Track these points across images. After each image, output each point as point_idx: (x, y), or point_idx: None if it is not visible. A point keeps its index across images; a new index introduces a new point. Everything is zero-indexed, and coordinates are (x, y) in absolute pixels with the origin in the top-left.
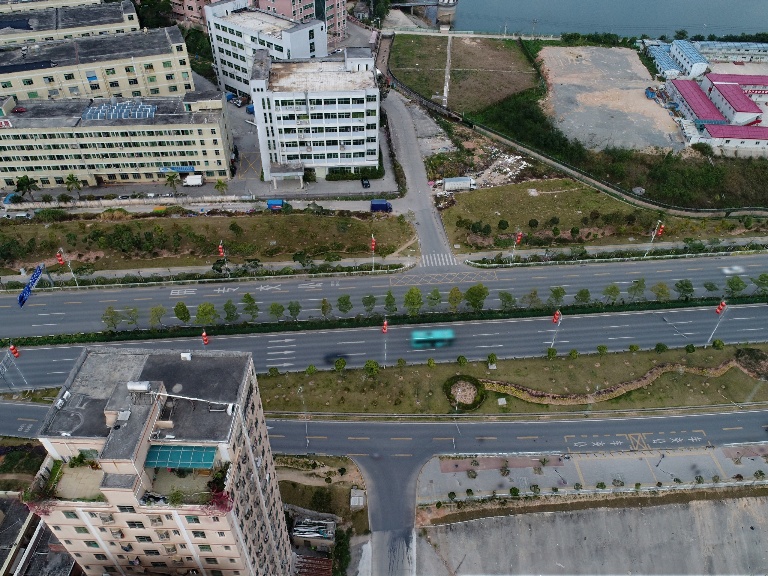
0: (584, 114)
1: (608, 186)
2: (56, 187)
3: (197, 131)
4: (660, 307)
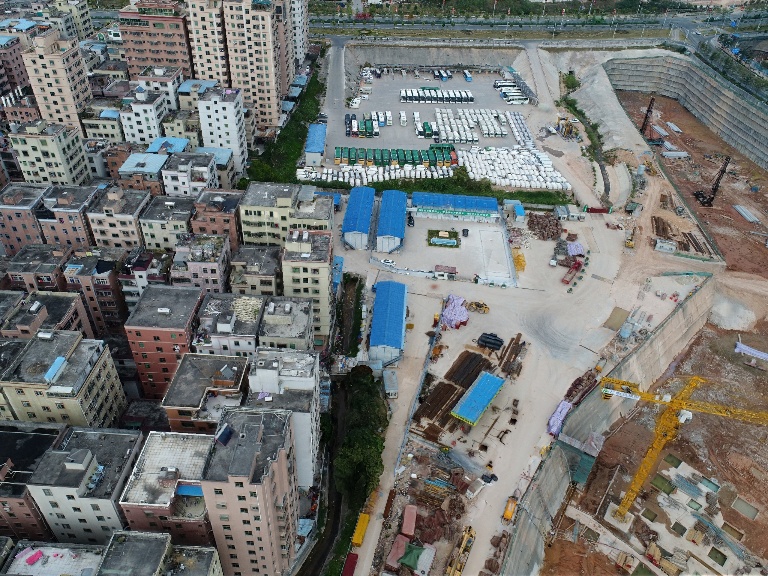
0: None
1: None
2: None
3: None
4: (440, 23)
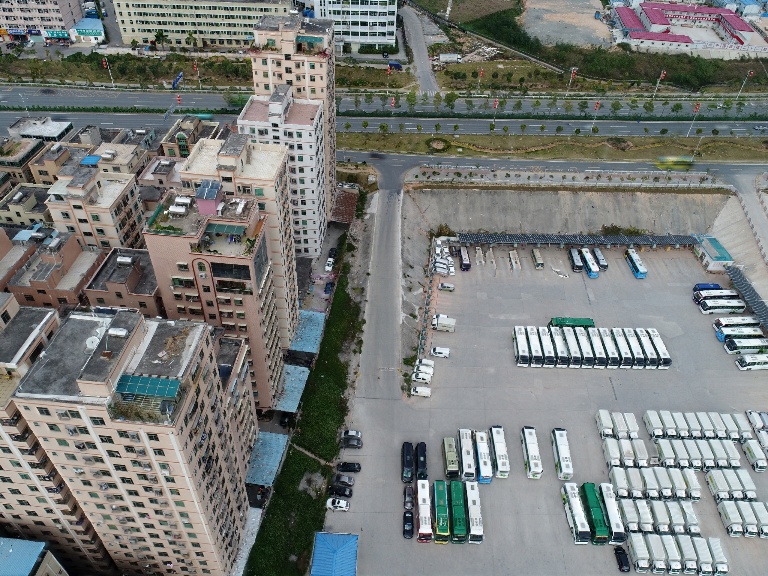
0: (546, 25)
1: (554, 66)
2: (175, 46)
3: (274, 9)
4: (568, 118)
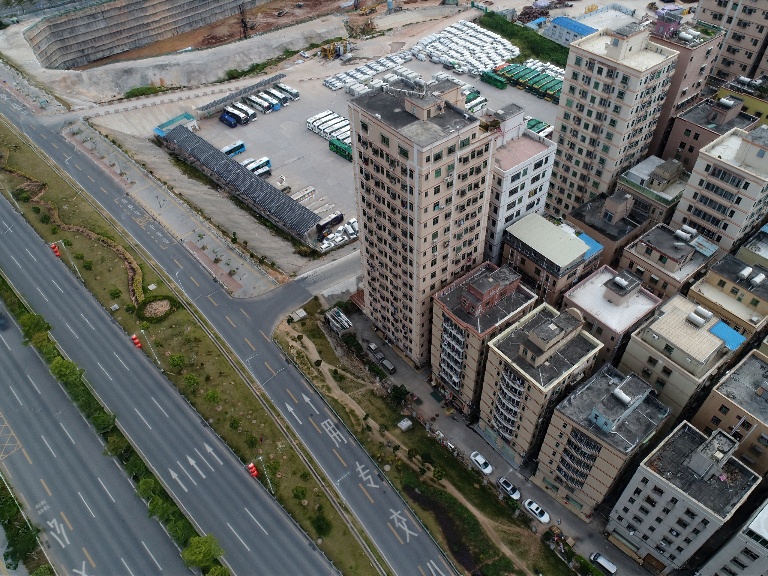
0: None
1: None
2: None
3: None
4: None
